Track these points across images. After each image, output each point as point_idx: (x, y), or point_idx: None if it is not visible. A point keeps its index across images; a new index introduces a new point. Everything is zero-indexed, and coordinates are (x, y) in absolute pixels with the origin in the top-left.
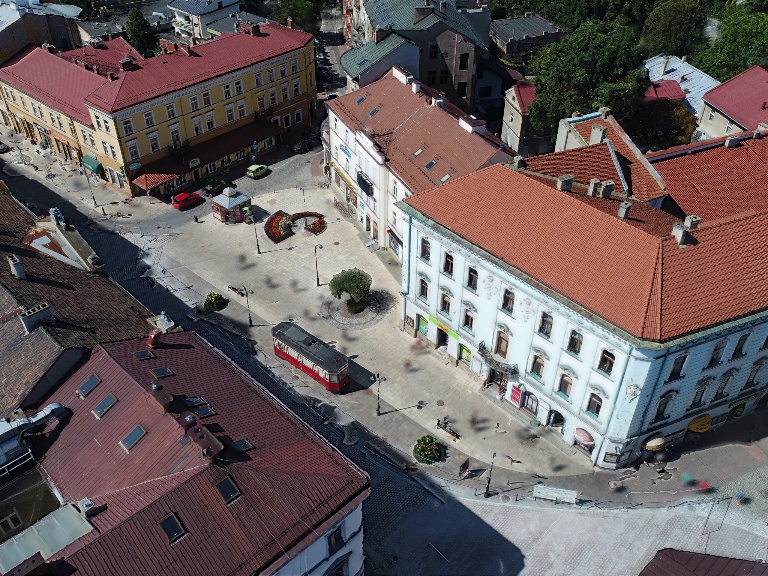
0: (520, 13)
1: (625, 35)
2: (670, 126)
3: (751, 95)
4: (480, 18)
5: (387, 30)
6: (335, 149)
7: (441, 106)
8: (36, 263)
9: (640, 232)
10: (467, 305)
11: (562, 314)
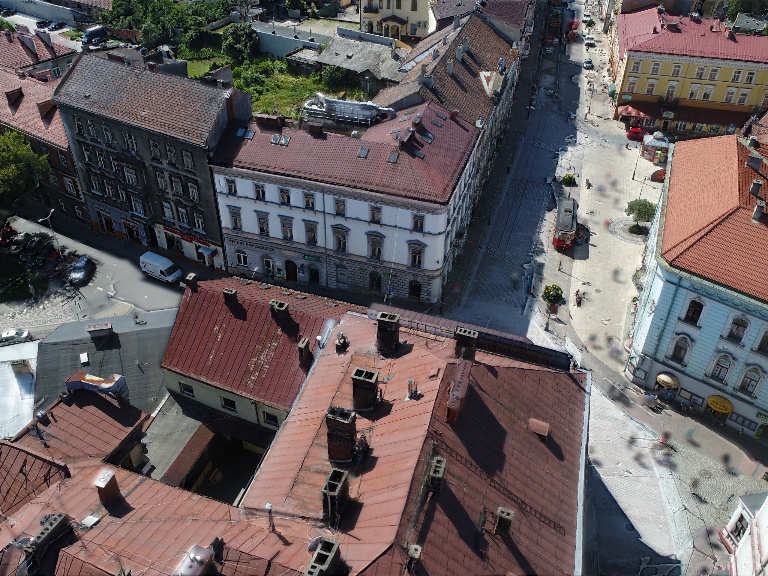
0: None
1: None
2: None
3: None
4: None
5: None
6: None
7: None
8: (468, 77)
9: None
10: None
11: None
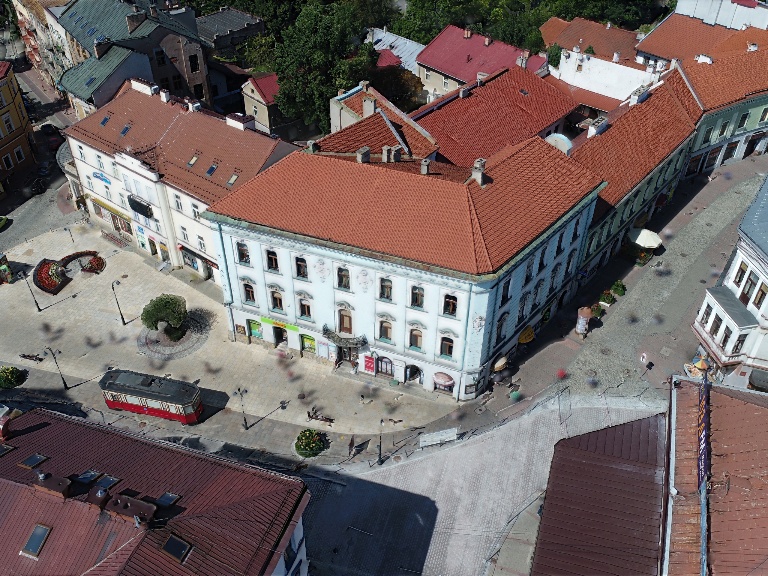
0: (215, 9)
1: (346, 13)
2: (403, 90)
3: (455, 51)
4: (185, 18)
5: (106, 43)
6: (87, 179)
7: (199, 110)
8: None
9: (447, 183)
10: (301, 295)
11: (400, 275)
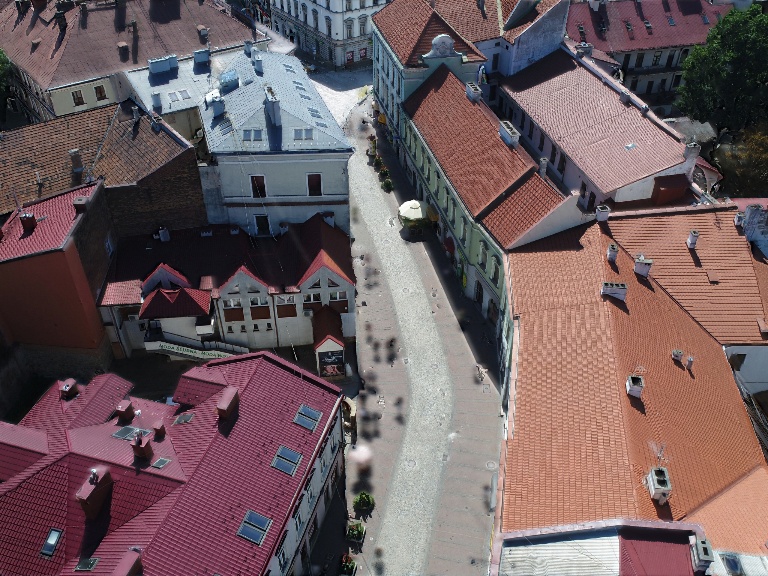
0: None
1: None
2: None
3: None
4: None
5: None
6: None
7: (638, 1)
8: None
9: None
10: None
11: None
